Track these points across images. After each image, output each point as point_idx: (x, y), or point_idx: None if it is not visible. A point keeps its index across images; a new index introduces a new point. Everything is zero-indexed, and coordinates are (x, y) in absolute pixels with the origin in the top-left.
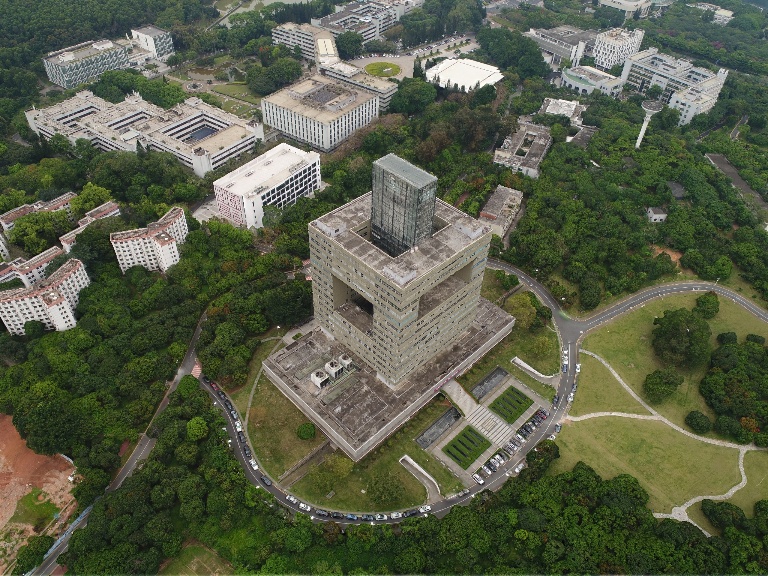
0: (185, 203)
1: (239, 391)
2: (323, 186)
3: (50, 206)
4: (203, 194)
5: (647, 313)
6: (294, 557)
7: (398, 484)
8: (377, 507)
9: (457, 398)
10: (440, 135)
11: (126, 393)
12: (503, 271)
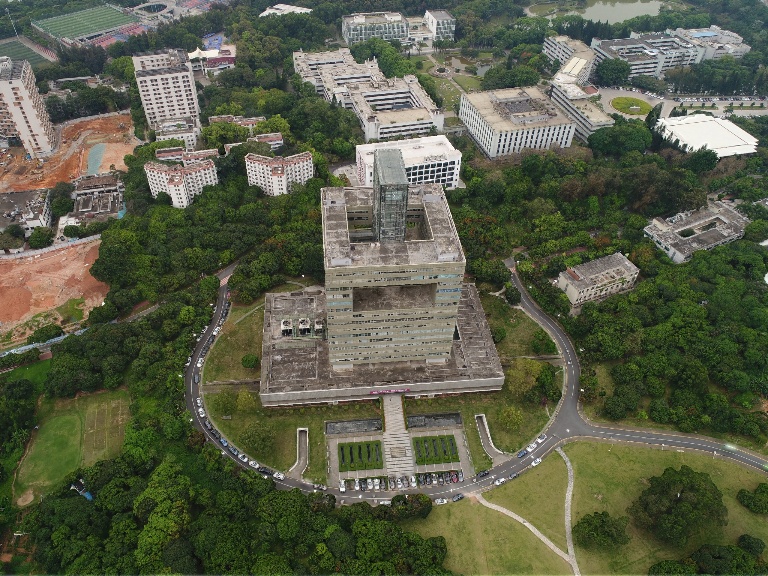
0: (337, 156)
1: (241, 308)
2: (460, 187)
3: (243, 122)
4: (354, 154)
5: (677, 460)
6: (162, 439)
7: (267, 440)
8: (248, 449)
9: (390, 412)
10: (596, 180)
11: (173, 268)
12: (545, 333)
